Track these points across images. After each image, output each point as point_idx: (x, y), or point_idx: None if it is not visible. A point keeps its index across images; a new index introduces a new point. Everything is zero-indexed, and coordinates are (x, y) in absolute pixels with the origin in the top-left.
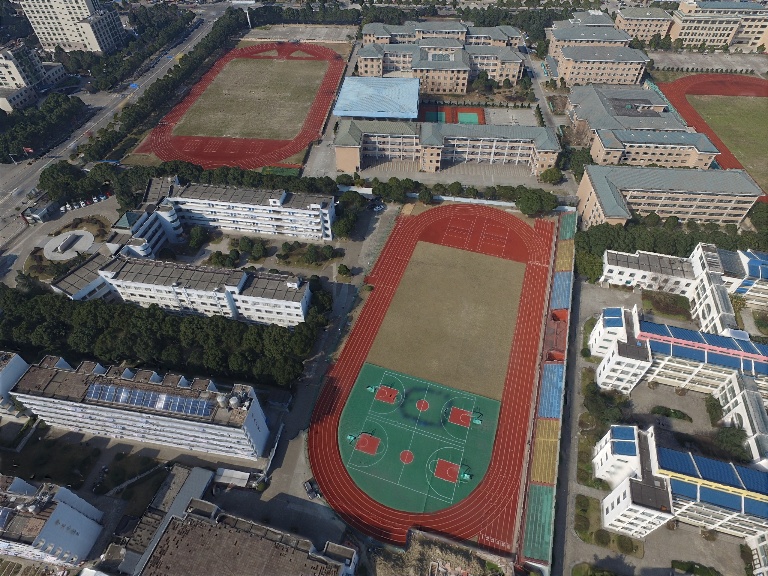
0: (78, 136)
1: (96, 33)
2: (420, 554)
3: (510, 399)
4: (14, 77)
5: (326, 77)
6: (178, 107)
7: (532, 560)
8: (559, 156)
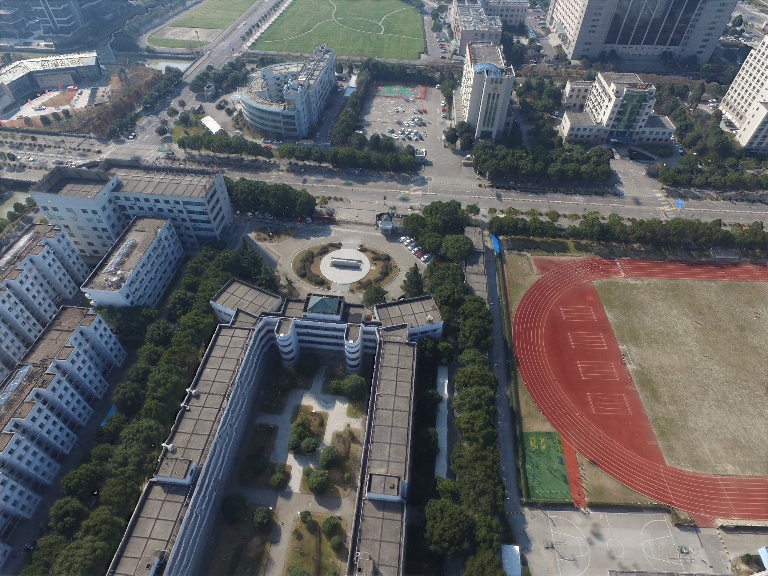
0: (548, 199)
1: (765, 125)
2: None
3: None
4: (606, 112)
5: None
6: (673, 265)
7: None
8: None
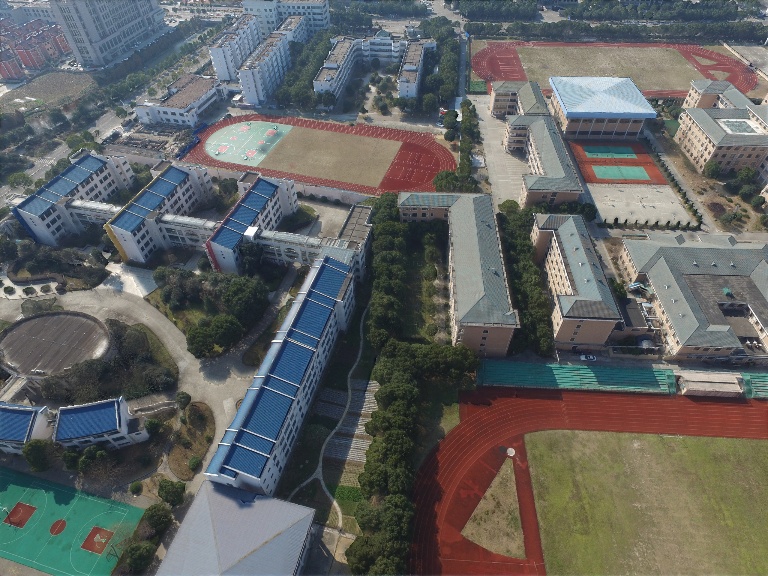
0: None
1: None
2: (186, 137)
3: (257, 170)
4: None
5: (671, 91)
6: (559, 43)
7: (168, 160)
8: (534, 202)
